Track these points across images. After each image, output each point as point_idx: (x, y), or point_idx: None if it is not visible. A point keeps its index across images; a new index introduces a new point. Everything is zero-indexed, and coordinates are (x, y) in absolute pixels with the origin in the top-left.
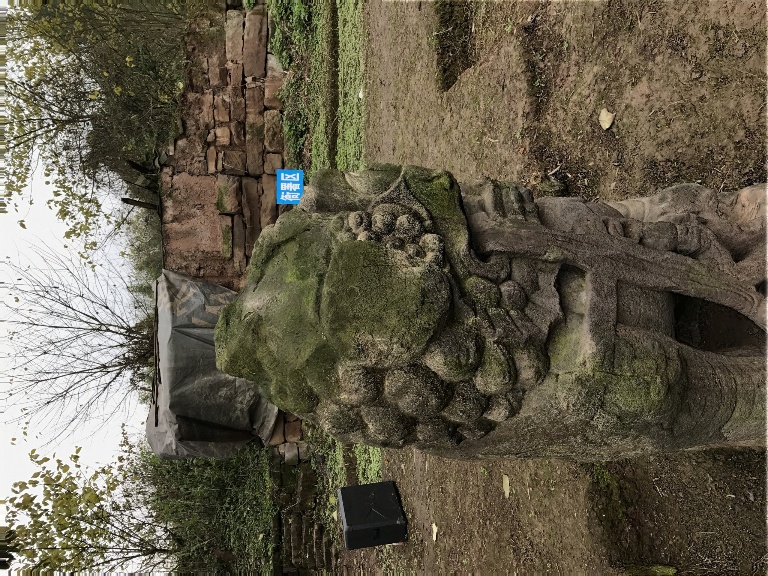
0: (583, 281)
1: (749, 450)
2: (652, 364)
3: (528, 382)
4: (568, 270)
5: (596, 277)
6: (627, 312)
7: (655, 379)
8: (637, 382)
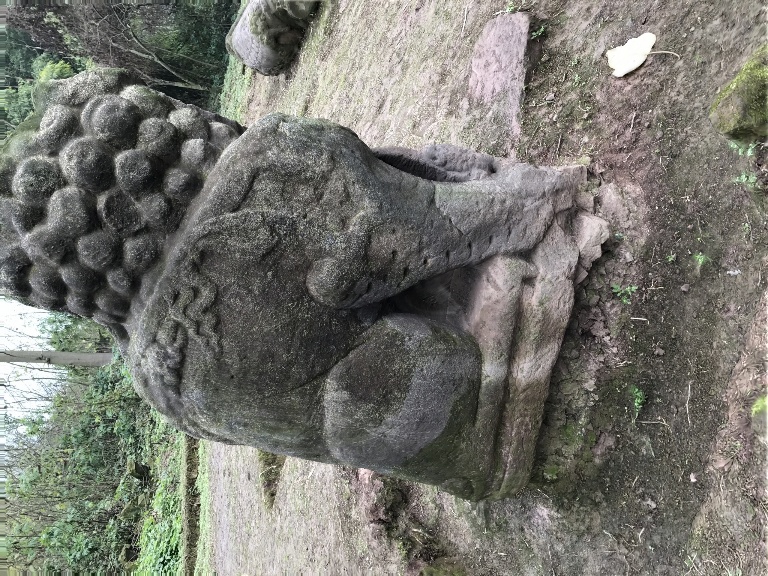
0: None
1: (608, 453)
2: None
3: (222, 133)
4: None
5: None
6: None
7: None
8: None
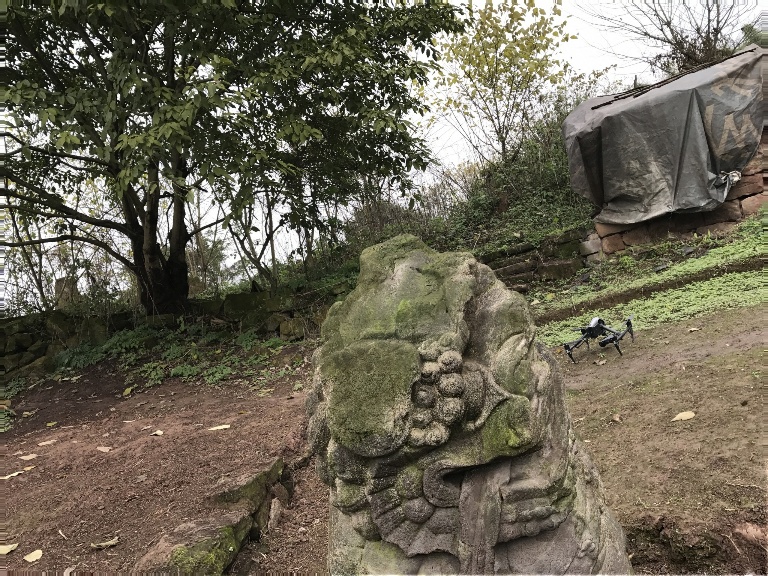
0: None
1: None
2: None
3: None
4: None
5: None
6: None
7: None
8: None
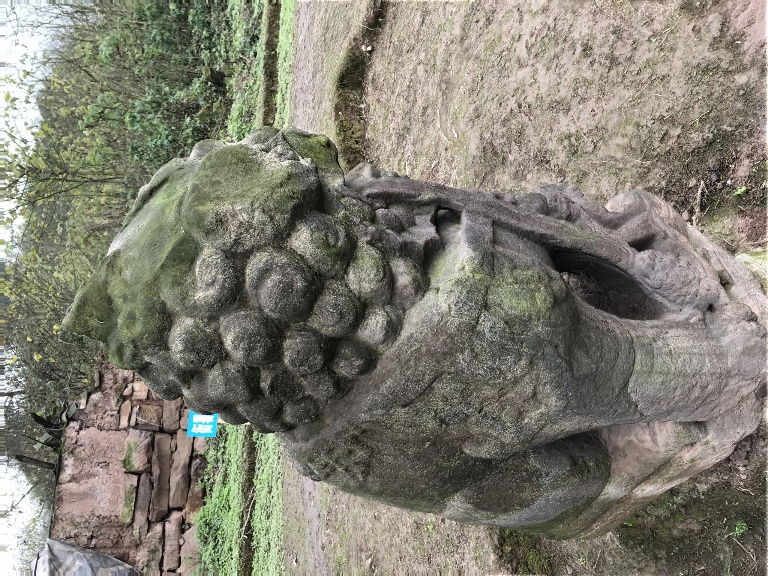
0: (460, 225)
1: (688, 532)
2: (534, 273)
3: (407, 292)
4: (446, 221)
5: (471, 215)
6: (505, 244)
7: (539, 288)
8: (520, 287)
